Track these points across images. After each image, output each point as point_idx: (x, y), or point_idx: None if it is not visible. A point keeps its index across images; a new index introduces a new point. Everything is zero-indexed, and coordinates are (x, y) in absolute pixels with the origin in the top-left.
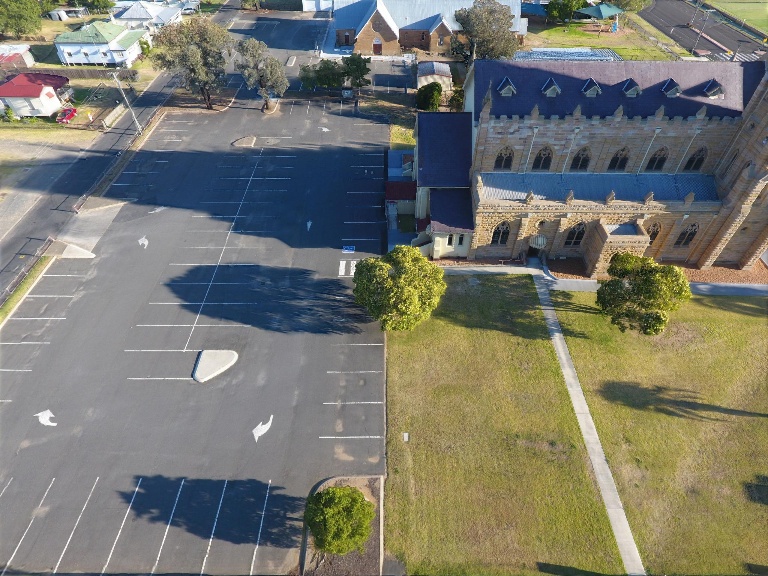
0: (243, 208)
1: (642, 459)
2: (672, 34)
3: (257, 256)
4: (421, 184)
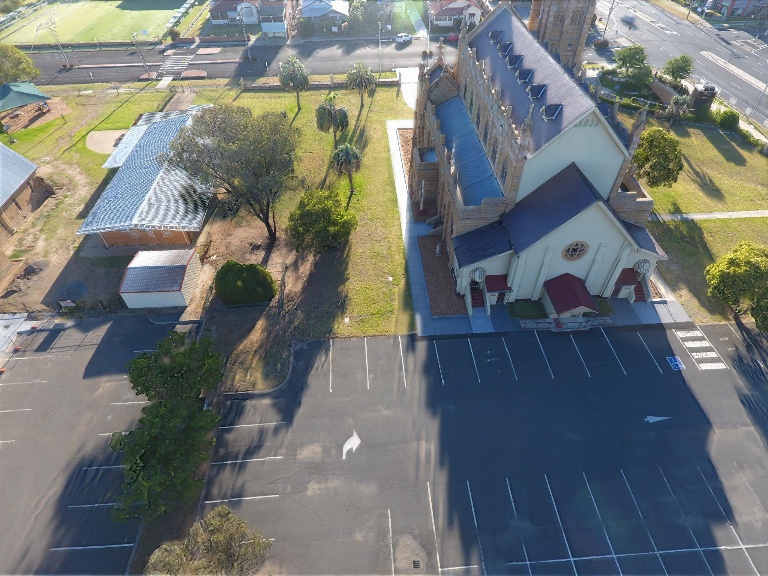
0: (672, 543)
1: (760, 197)
2: (82, 80)
3: (765, 479)
4: (638, 245)
